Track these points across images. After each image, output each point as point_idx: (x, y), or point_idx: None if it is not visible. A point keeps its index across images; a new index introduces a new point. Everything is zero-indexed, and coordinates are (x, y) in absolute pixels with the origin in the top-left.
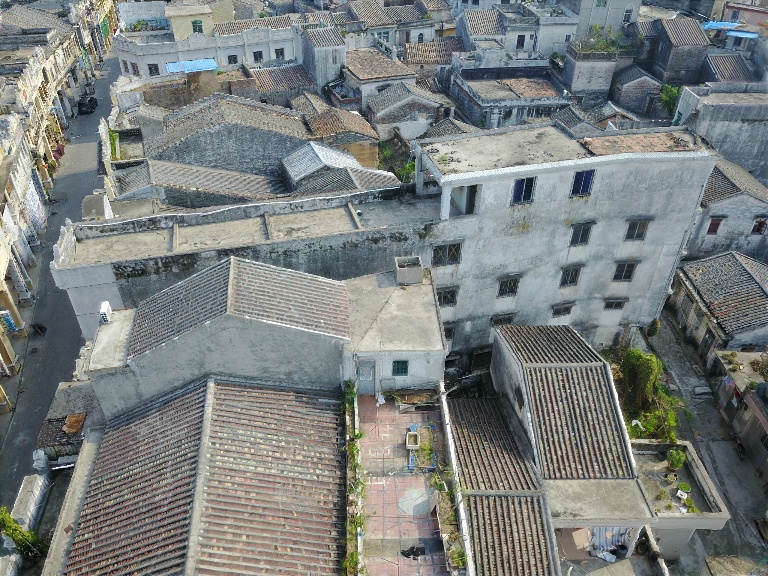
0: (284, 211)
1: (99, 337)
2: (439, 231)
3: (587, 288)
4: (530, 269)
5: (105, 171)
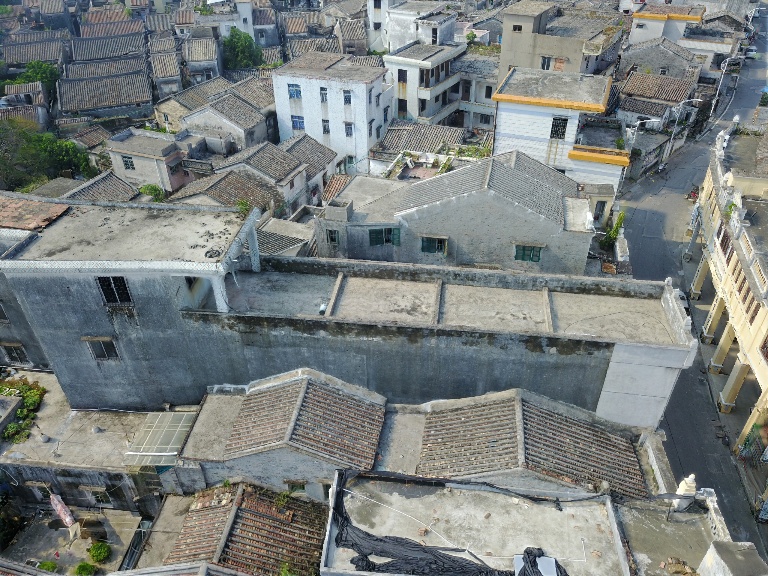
0: None
1: None
2: None
3: None
4: None
5: None
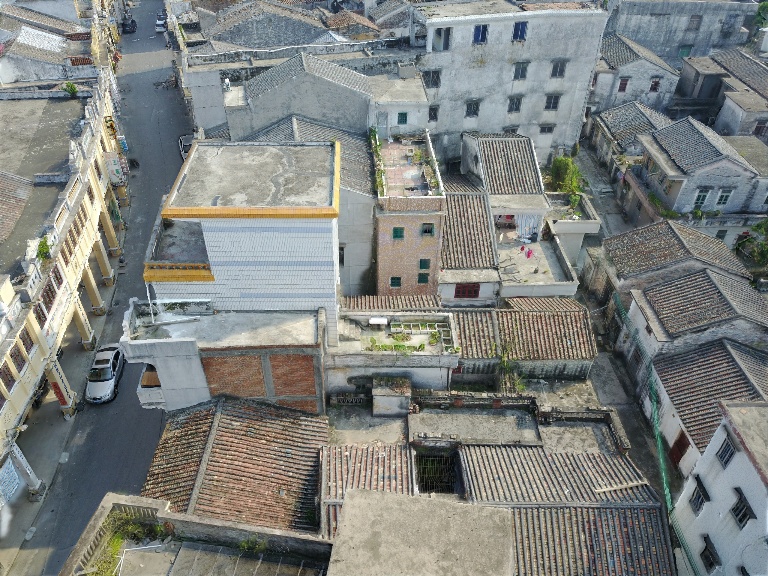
0: (322, 52)
1: (226, 96)
2: (425, 61)
3: (527, 116)
4: (487, 96)
5: (179, 48)
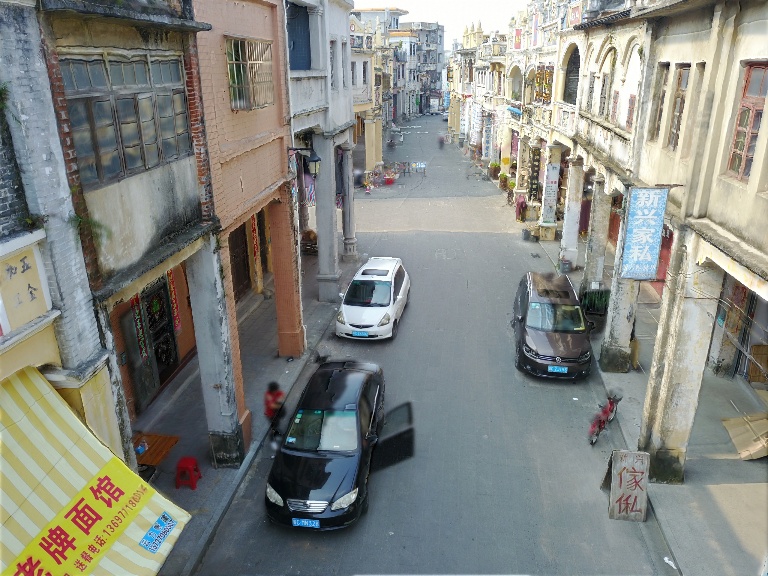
0: None
1: None
2: None
3: None
4: None
5: None
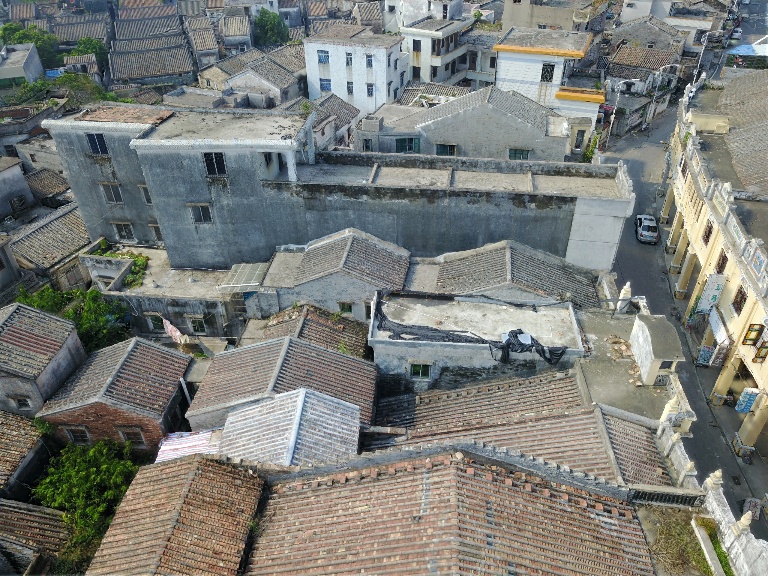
0: None
1: None
2: None
3: None
4: None
5: None
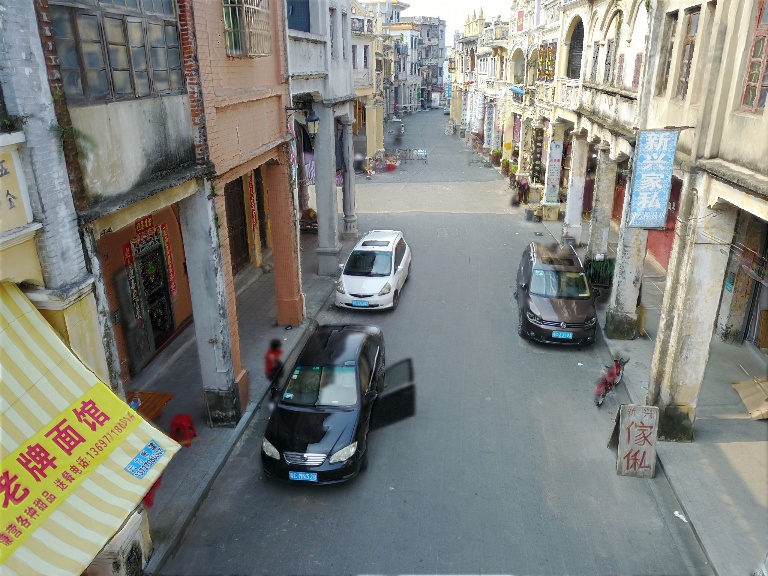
0: None
1: None
2: None
3: None
4: None
5: None
